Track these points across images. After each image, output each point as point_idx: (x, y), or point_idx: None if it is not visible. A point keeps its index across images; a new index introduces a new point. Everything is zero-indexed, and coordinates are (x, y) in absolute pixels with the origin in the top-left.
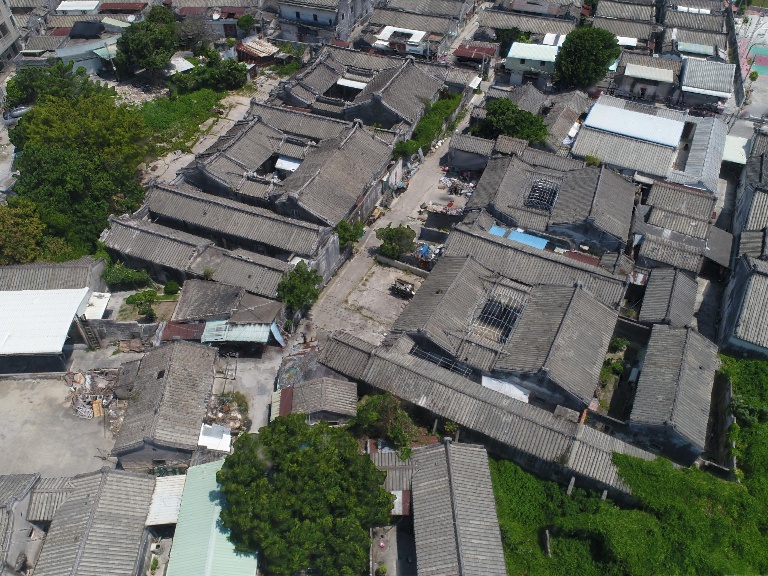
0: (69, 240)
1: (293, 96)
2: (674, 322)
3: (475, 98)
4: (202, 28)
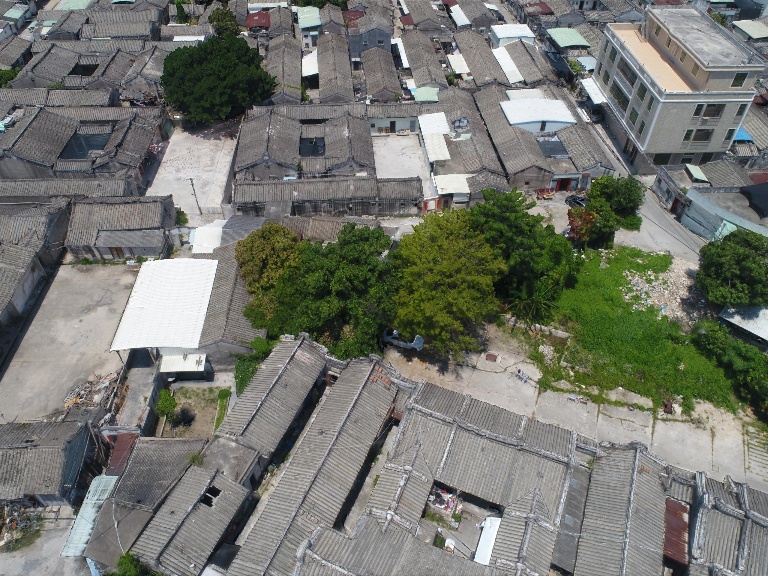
0: None
1: (699, 516)
2: None
3: None
4: None
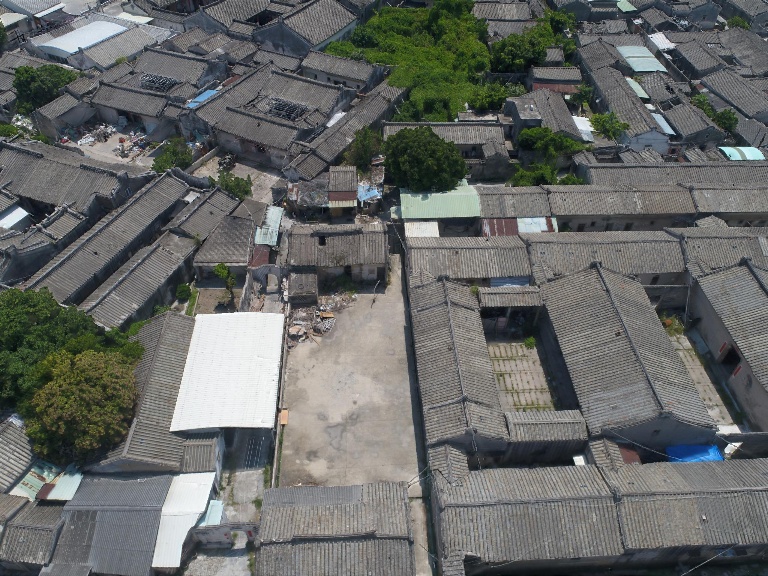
0: (103, 351)
1: None
2: None
3: None
4: None
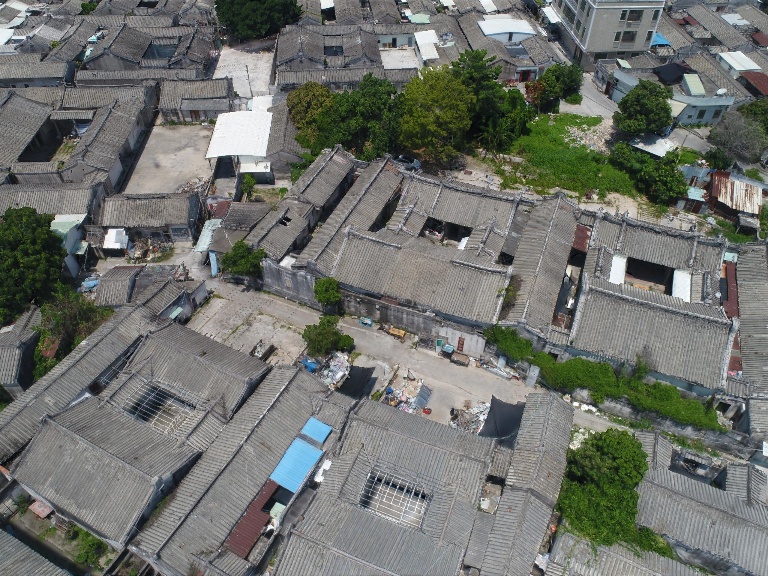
0: None
1: None
2: None
3: None
4: (729, 136)
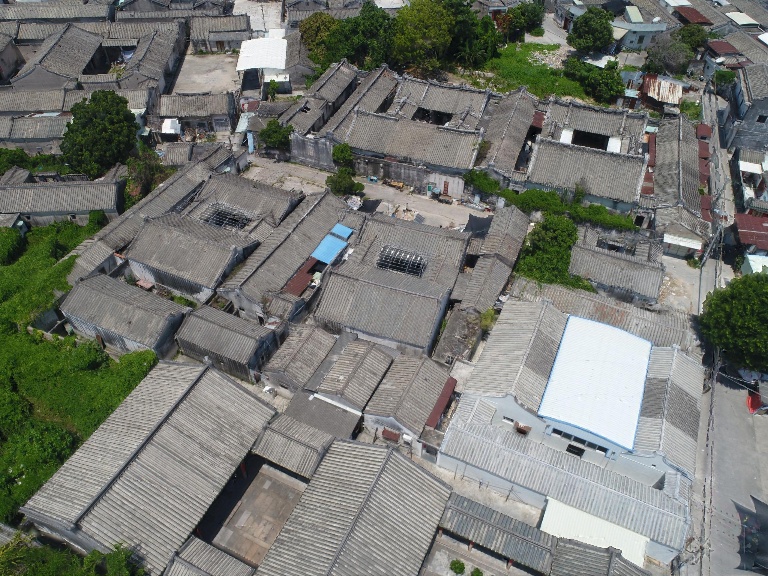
0: None
1: None
2: (191, 322)
3: (674, 260)
4: (659, 49)
